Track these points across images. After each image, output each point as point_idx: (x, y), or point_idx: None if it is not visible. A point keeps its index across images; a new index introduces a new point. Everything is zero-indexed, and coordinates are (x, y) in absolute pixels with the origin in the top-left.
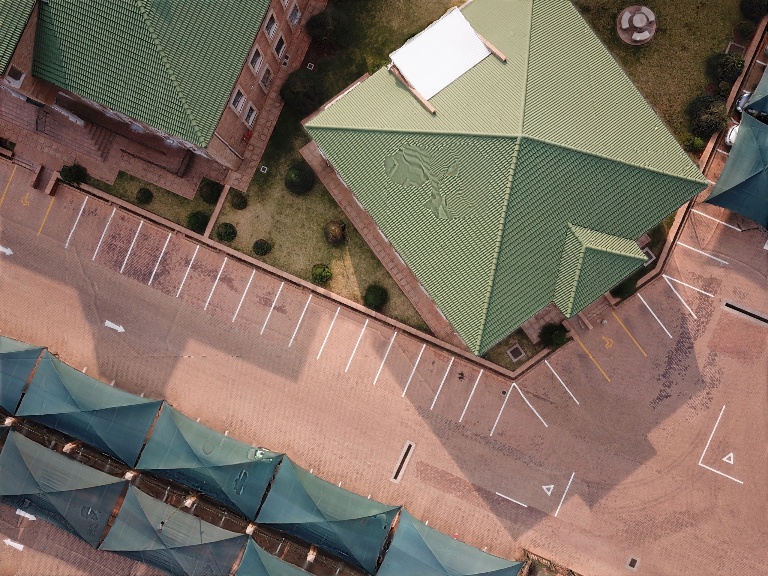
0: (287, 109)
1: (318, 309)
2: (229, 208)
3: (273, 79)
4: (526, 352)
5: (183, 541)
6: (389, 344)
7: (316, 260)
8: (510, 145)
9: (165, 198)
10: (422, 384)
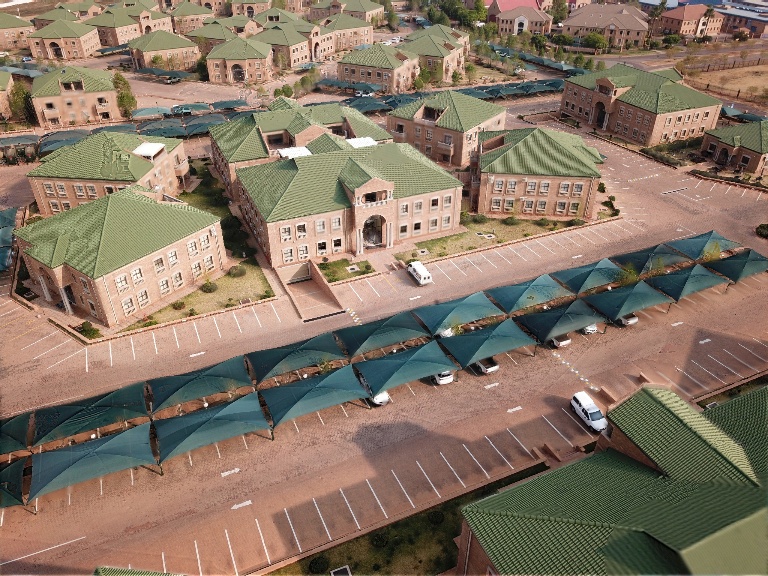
0: None
1: None
2: None
3: None
4: None
5: (156, 123)
6: None
7: None
8: None
9: None
10: None
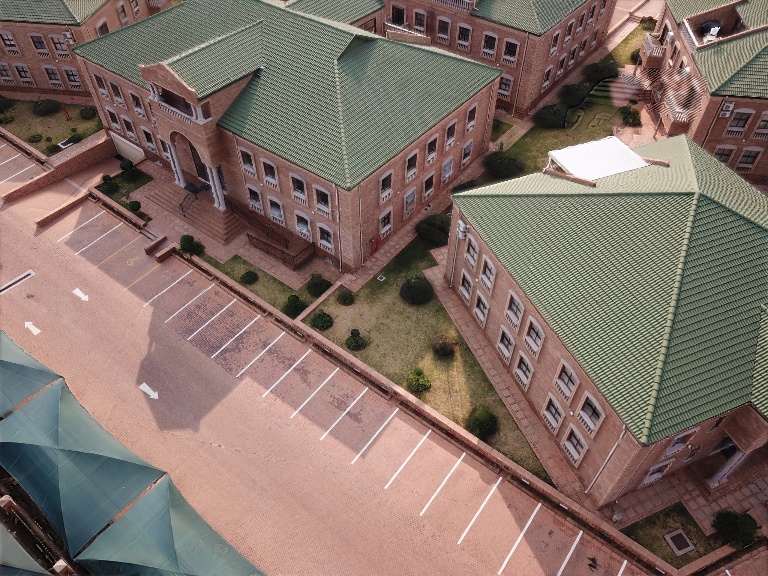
0: (419, 240)
1: (402, 426)
2: (333, 301)
3: (413, 214)
4: (695, 545)
5: None
6: (489, 491)
7: (415, 368)
8: (686, 201)
9: (269, 283)
10: (531, 561)
